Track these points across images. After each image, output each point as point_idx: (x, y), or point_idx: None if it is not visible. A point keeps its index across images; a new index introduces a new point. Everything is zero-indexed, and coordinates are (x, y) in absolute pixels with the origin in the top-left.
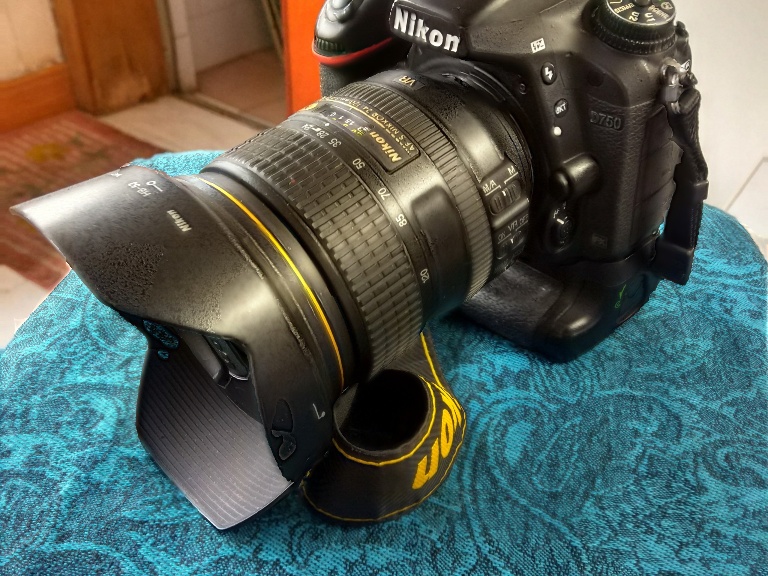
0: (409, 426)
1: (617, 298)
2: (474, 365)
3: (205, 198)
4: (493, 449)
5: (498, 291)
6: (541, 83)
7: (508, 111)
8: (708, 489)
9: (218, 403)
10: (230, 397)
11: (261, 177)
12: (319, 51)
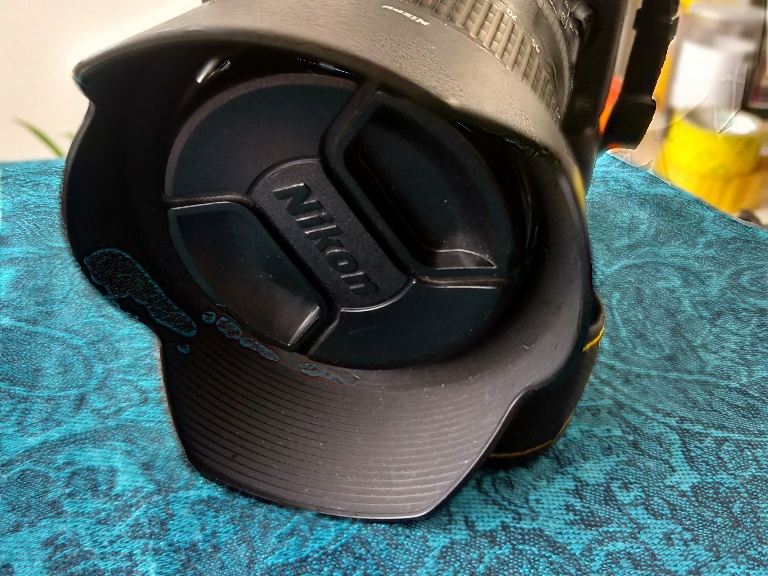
0: None
1: (591, 174)
2: None
3: None
4: None
5: None
6: None
7: None
8: (766, 309)
9: (281, 389)
10: (323, 361)
11: None
12: None
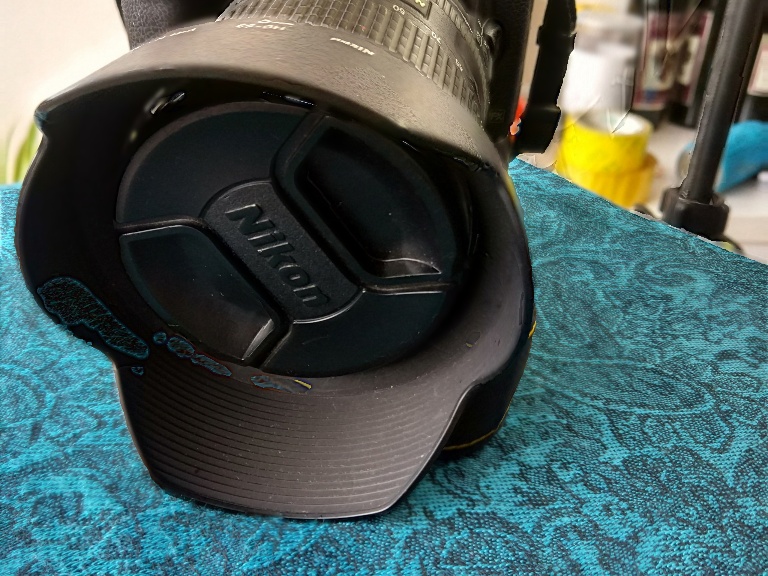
0: None
1: None
2: None
3: None
4: None
5: None
6: None
7: None
8: (671, 295)
9: (236, 402)
10: (277, 372)
11: None
12: None
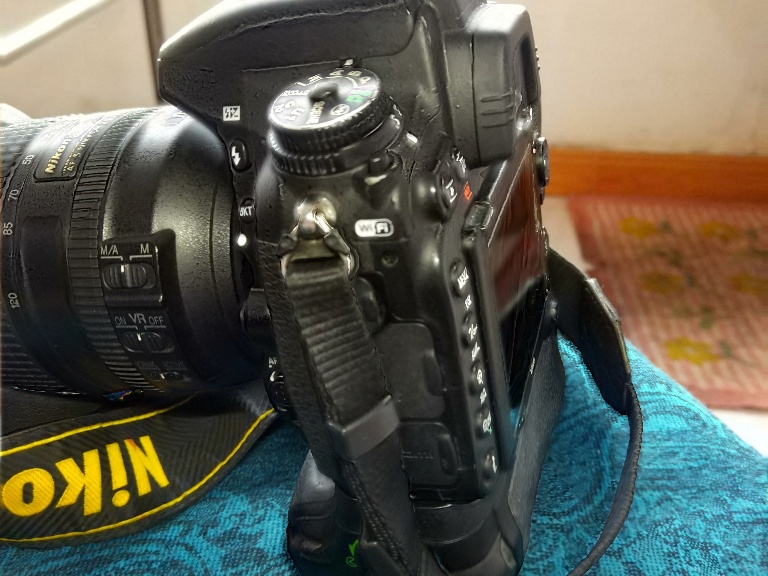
0: None
1: (349, 550)
2: (247, 505)
3: None
4: (105, 571)
5: None
6: (231, 165)
7: None
8: None
9: None
10: None
11: None
12: None
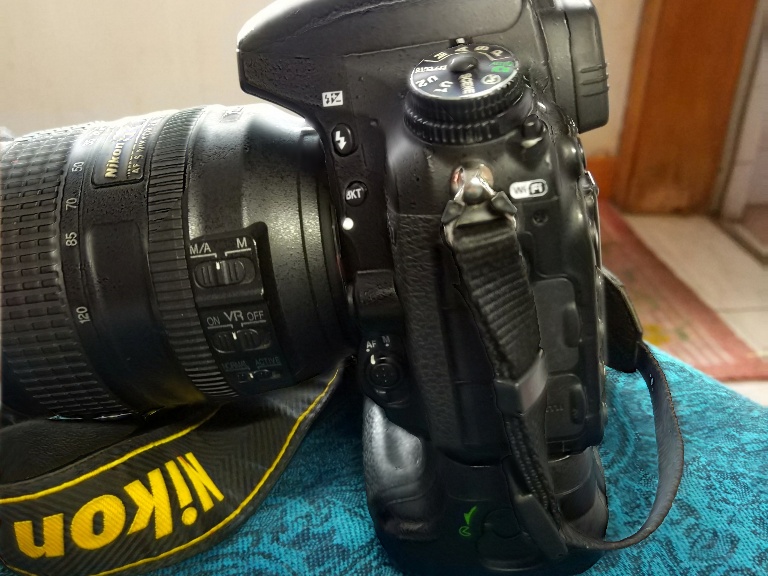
0: None
1: (463, 520)
2: (309, 506)
3: None
4: None
5: (384, 438)
6: (333, 150)
7: None
8: None
9: None
10: None
11: None
12: None
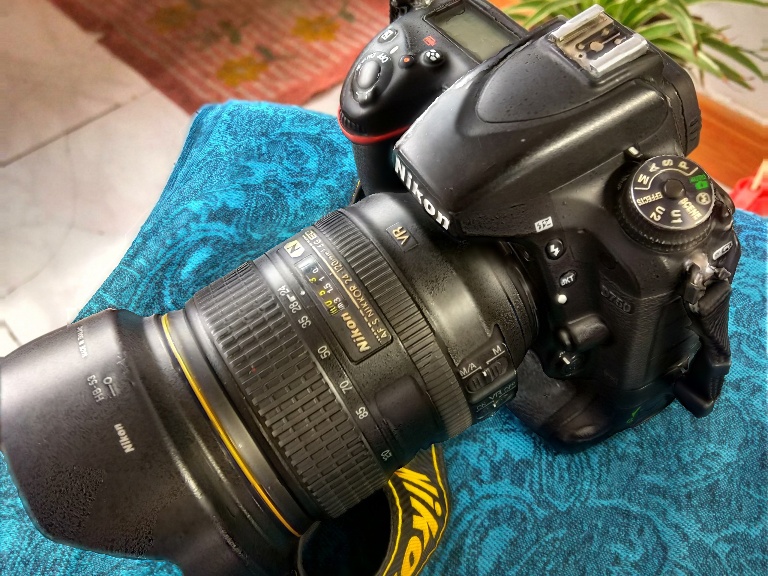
0: (371, 557)
1: (629, 416)
2: (476, 445)
3: (163, 389)
4: (467, 554)
5: None
6: (545, 258)
7: (513, 265)
8: None
9: None
10: None
11: (224, 359)
12: (342, 124)
